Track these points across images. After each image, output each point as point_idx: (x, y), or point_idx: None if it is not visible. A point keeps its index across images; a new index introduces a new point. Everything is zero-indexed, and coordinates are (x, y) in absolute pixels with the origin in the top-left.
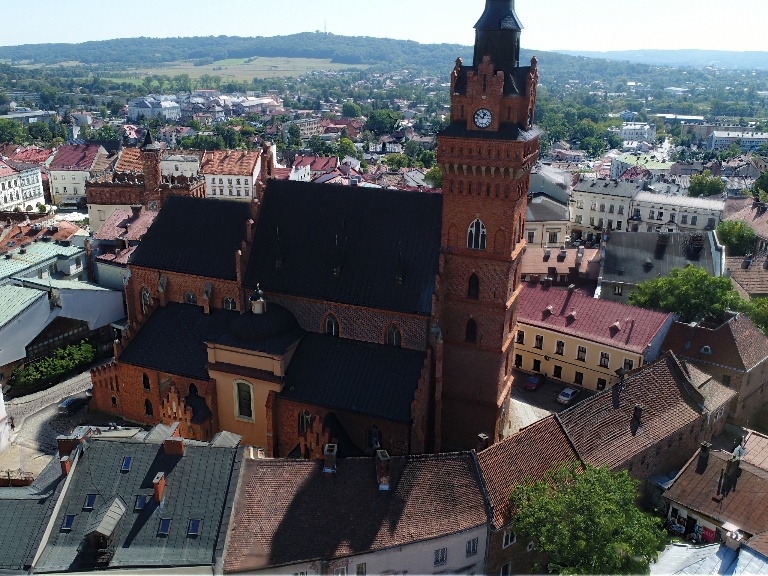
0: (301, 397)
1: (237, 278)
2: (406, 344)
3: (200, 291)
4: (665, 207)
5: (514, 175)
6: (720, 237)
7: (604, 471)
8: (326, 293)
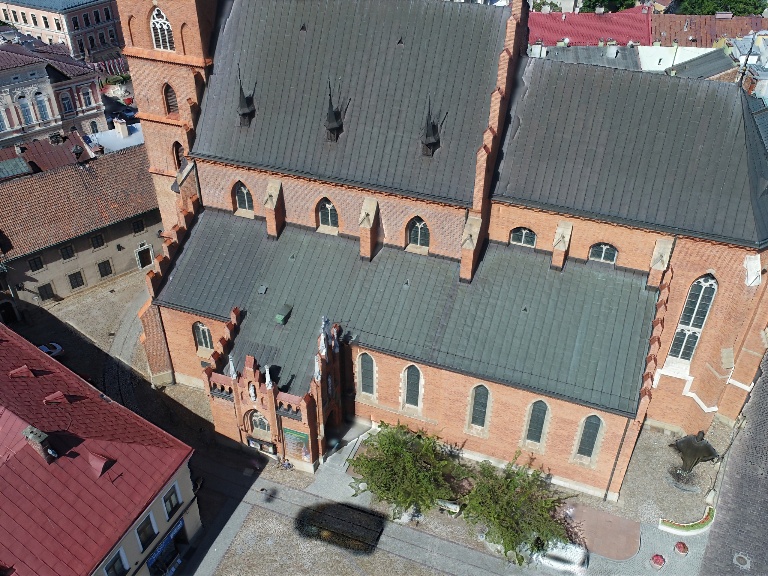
0: None
1: None
2: None
3: None
4: None
5: None
6: None
7: None
8: None
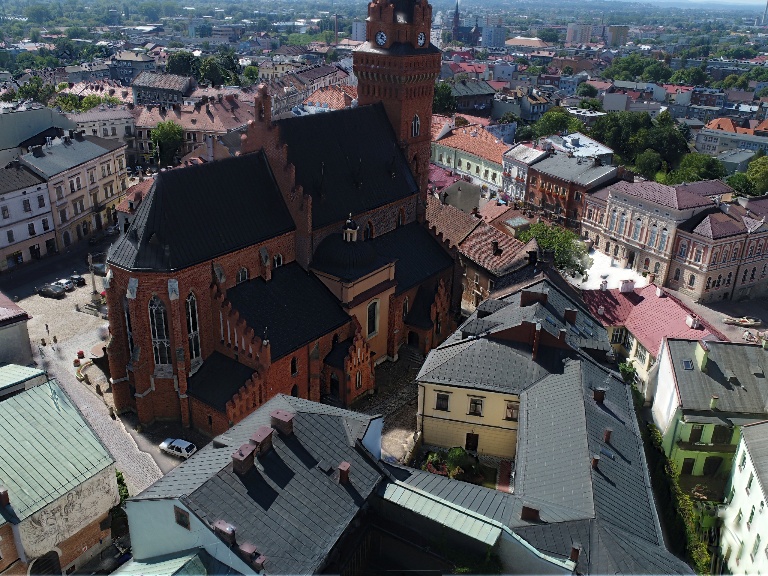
0: (404, 288)
1: (308, 224)
2: None
3: (253, 262)
4: (86, 125)
5: None
6: (164, 137)
7: None
8: (364, 206)
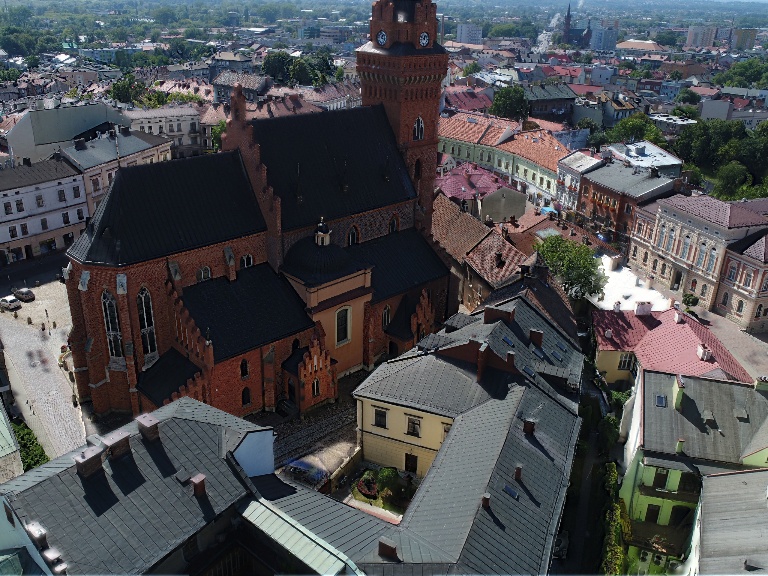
0: (384, 296)
1: (277, 225)
2: (402, 227)
3: (217, 261)
4: (153, 121)
5: (441, 79)
6: None
7: (557, 236)
8: (347, 209)
